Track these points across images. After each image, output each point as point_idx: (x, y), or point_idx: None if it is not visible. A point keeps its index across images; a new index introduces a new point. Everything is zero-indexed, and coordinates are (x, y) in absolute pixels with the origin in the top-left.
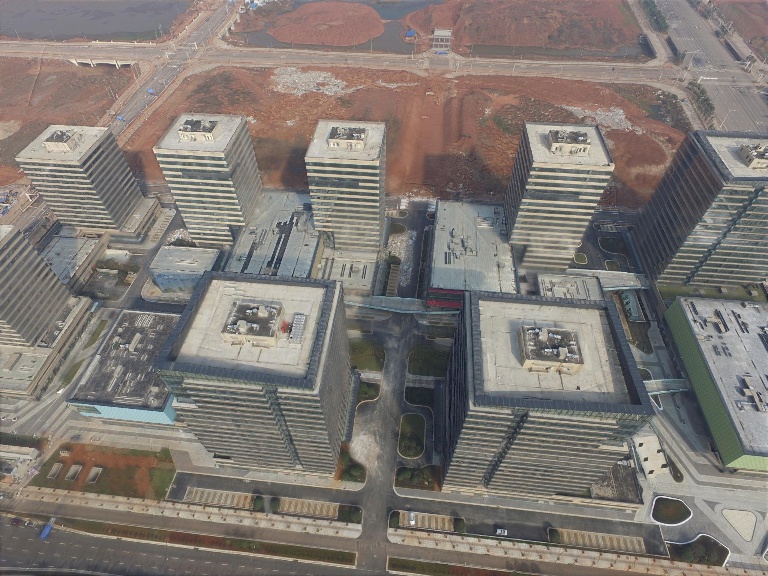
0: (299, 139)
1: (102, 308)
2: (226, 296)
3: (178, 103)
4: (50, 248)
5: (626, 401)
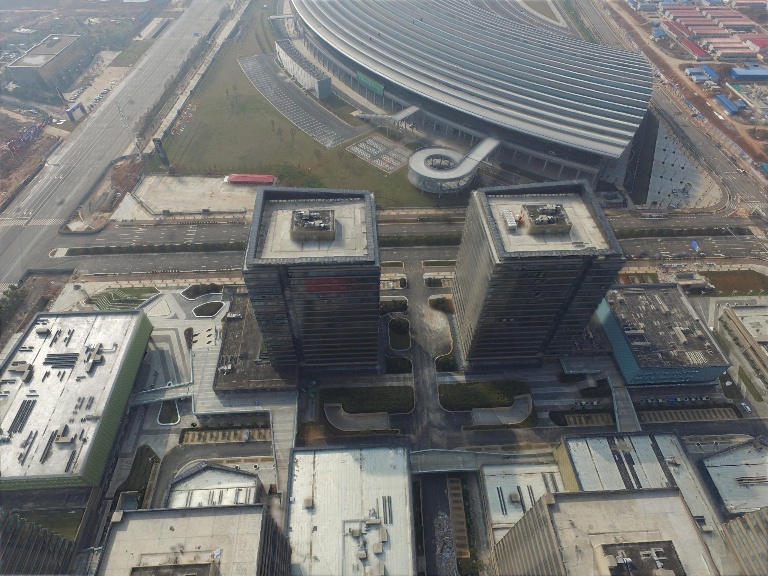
0: None
1: None
2: (588, 242)
3: None
4: None
5: (267, 207)
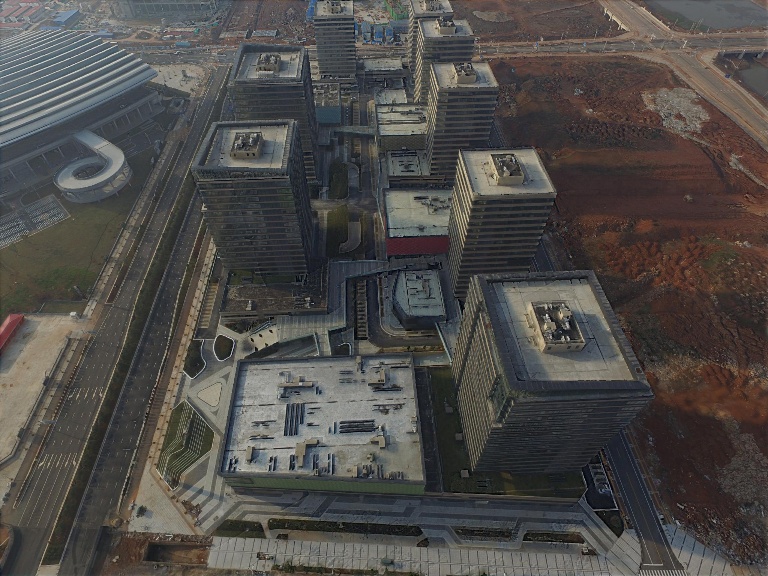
0: (565, 119)
1: (358, 91)
2: None
3: (581, 60)
4: (391, 59)
5: None
